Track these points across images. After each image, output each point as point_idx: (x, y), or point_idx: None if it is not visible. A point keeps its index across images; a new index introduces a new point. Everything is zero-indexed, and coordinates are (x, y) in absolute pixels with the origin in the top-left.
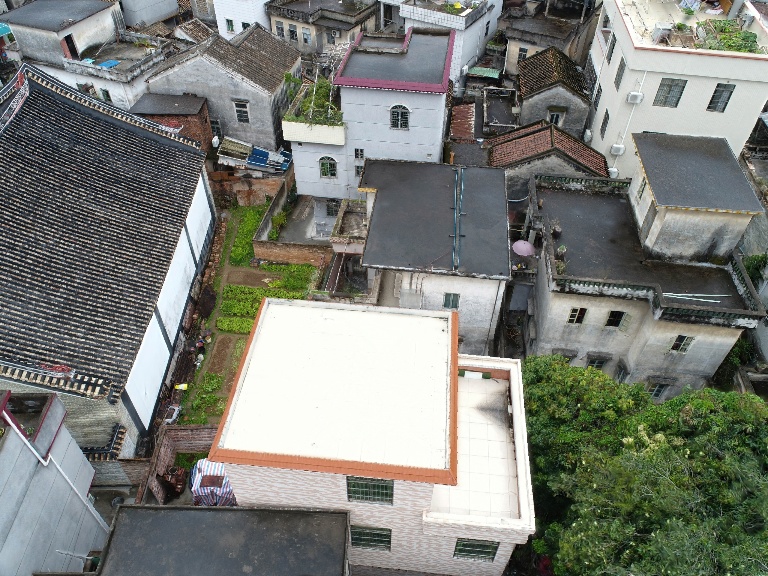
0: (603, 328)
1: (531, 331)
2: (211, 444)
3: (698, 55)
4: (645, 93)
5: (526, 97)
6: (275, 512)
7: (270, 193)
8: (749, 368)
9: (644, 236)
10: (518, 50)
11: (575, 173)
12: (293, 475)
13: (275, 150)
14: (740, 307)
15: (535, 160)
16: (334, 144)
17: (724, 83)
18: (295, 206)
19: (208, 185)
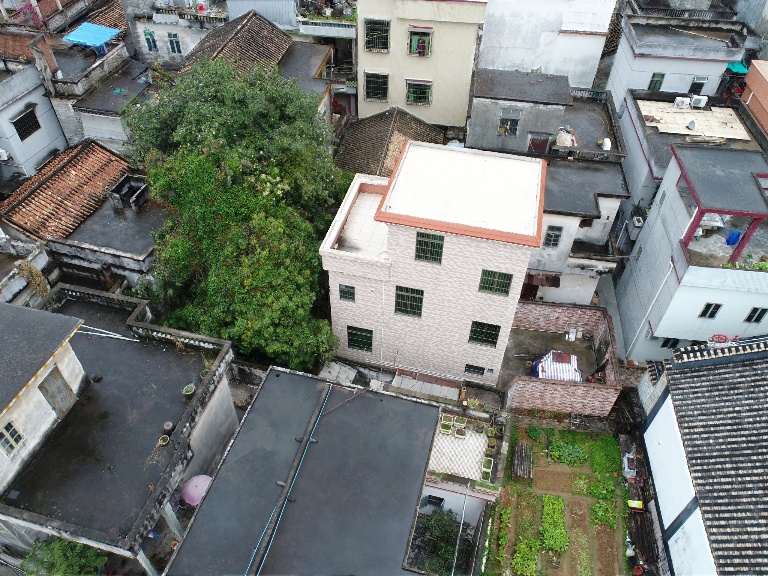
0: None
1: None
2: None
3: None
4: None
5: None
6: None
7: None
8: None
9: None
10: None
11: None
12: None
13: None
14: None
15: None
16: None
17: None
18: None
19: None
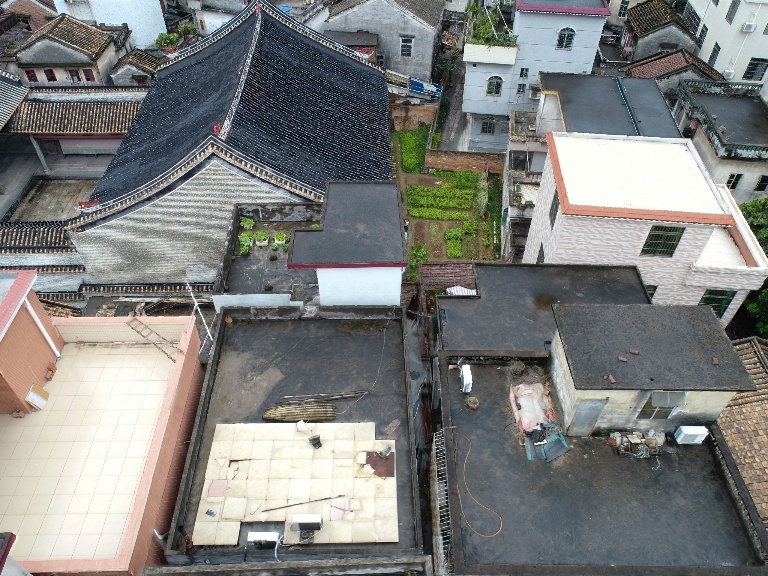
0: (752, 192)
1: None
2: (449, 281)
3: None
4: (758, 23)
5: (642, 35)
6: (583, 268)
7: (422, 119)
8: None
9: None
10: (620, 3)
11: None
12: (611, 230)
13: (429, 81)
14: None
15: (673, 75)
16: (506, 64)
17: None
18: (442, 131)
19: None
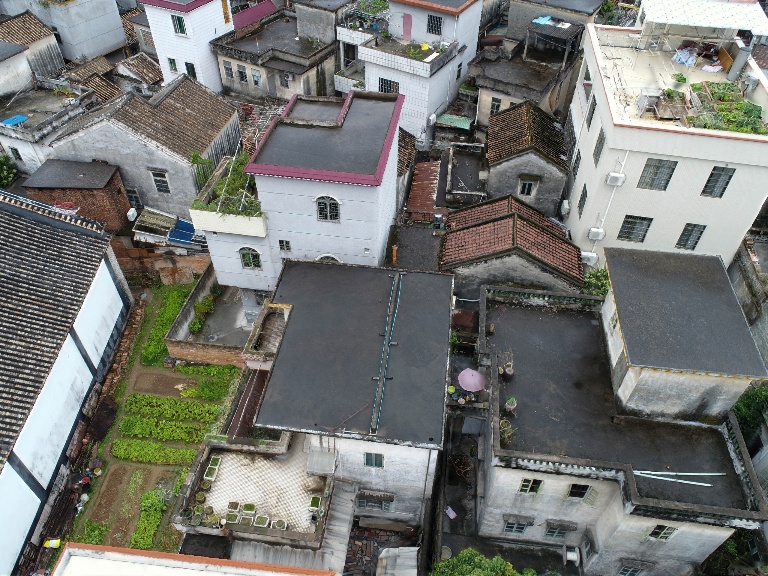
0: (564, 499)
1: (479, 485)
2: None
3: (690, 135)
4: (627, 174)
5: (493, 164)
6: None
7: (198, 271)
8: (748, 570)
9: (617, 383)
10: (491, 100)
11: (541, 274)
12: None
13: None
14: (737, 494)
15: (493, 259)
16: (253, 235)
17: (722, 166)
18: None
19: (118, 269)
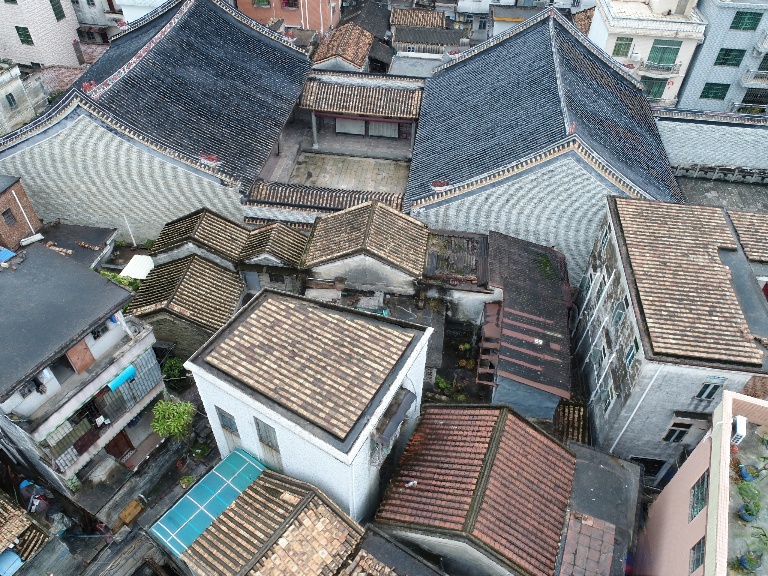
0: None
1: None
2: None
3: None
4: None
5: None
6: None
7: None
8: None
9: None
10: None
11: None
12: None
13: None
14: None
15: None
16: None
17: None
18: None
19: None
